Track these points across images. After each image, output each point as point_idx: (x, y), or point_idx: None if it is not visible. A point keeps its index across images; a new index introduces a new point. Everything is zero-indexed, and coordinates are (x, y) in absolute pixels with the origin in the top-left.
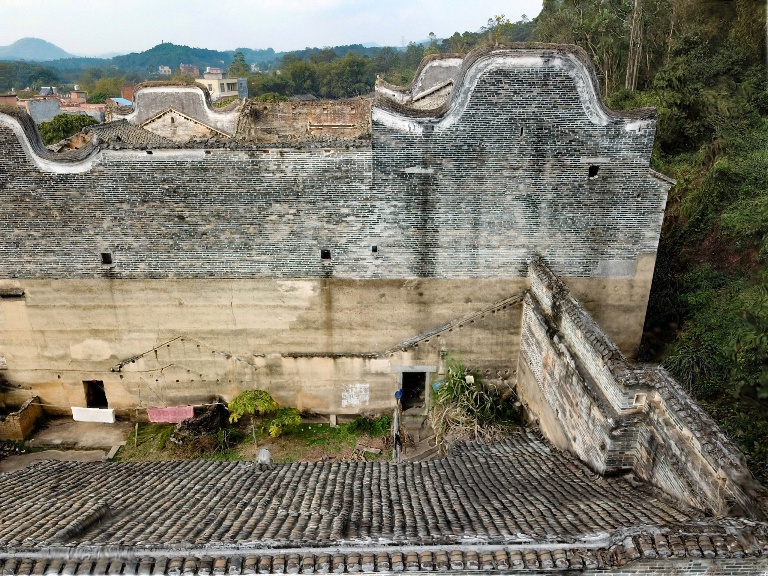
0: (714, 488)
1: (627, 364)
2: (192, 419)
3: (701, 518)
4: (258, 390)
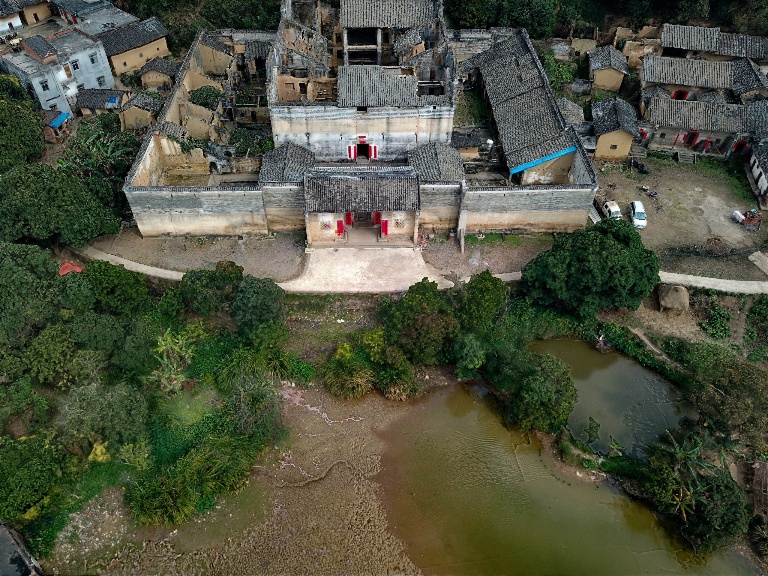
0: (511, 33)
1: (489, 29)
2: None
3: (510, 38)
4: None
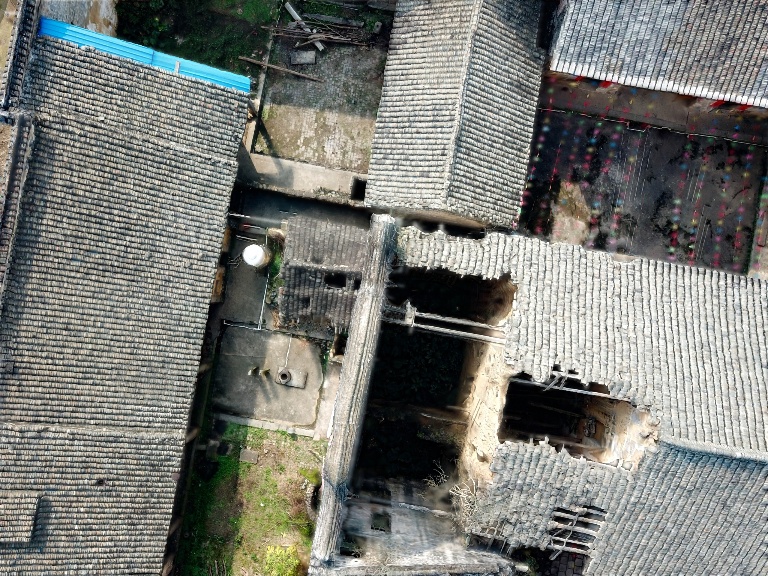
0: None
1: None
2: (308, 504)
3: None
4: (290, 575)
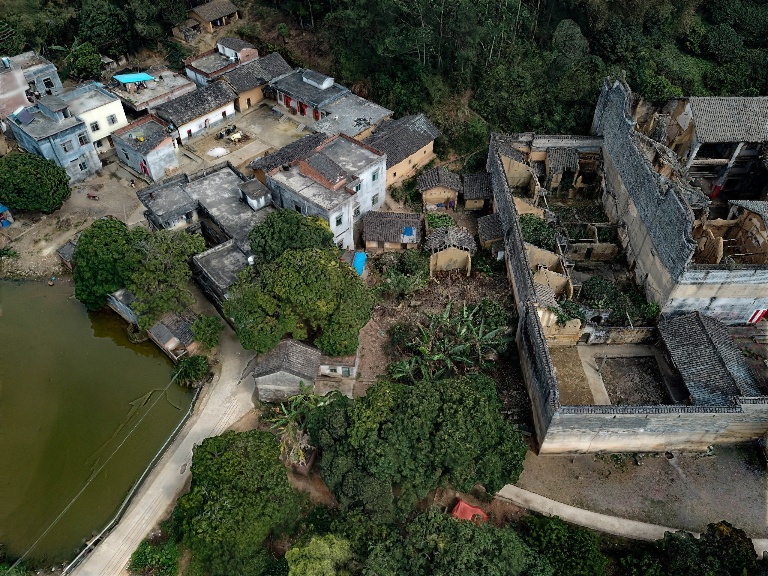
0: None
1: None
2: None
3: None
4: None
